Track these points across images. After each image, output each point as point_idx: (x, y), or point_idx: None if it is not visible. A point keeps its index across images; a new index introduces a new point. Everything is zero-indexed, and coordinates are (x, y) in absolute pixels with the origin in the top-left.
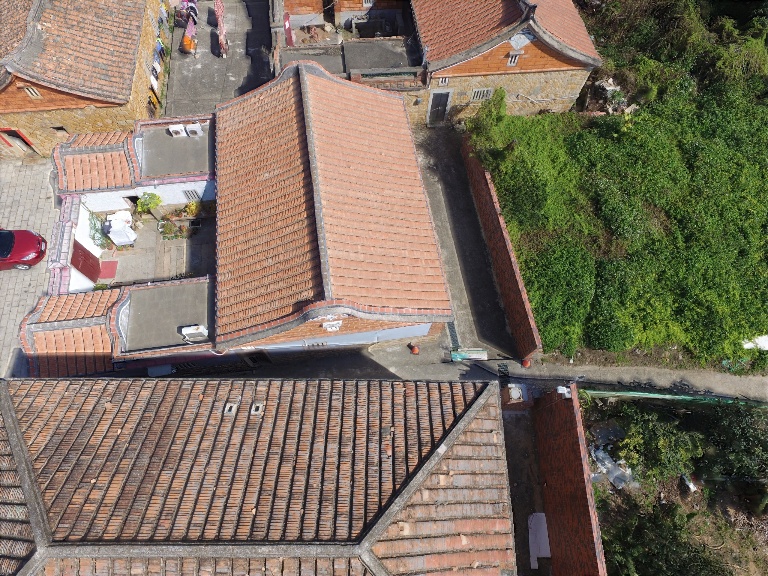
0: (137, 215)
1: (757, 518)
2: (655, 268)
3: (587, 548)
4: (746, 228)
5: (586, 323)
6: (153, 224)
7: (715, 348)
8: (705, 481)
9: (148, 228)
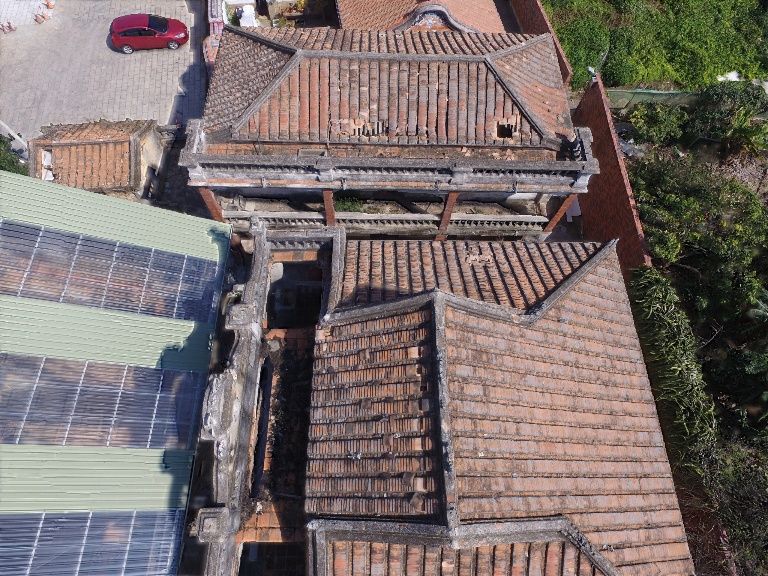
0: (257, 12)
1: (725, 161)
2: (653, 30)
3: (610, 163)
4: (720, 6)
5: (603, 67)
6: (267, 23)
7: (697, 78)
8: (690, 149)
9: (264, 25)
